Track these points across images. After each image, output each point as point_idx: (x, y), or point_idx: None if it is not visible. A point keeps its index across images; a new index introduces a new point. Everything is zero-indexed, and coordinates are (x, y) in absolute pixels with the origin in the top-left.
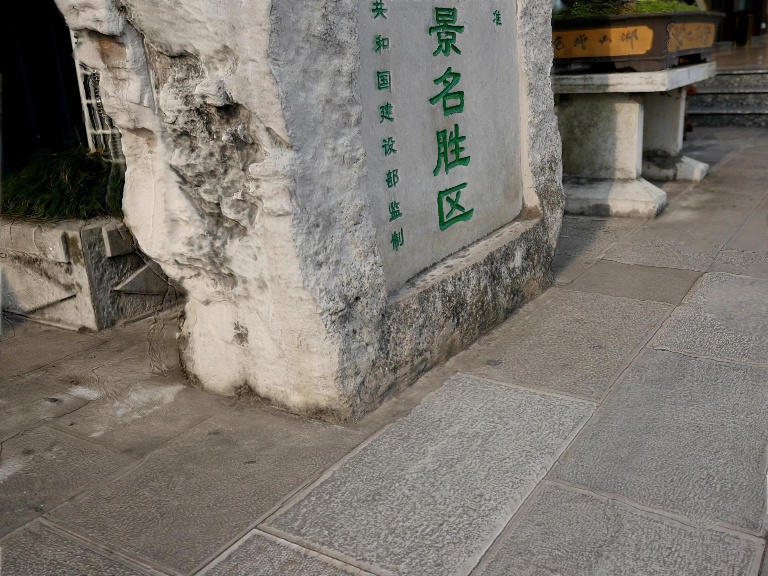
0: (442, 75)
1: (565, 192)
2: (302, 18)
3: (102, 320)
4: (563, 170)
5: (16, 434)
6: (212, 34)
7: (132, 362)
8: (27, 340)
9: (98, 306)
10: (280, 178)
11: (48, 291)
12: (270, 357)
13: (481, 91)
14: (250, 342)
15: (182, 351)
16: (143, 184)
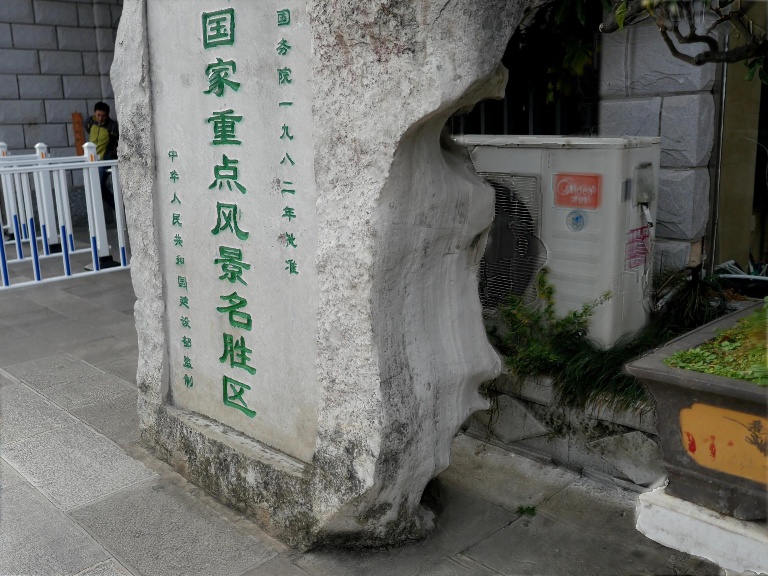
0: (230, 295)
1: None
2: None
3: None
4: None
5: None
6: None
7: None
8: None
9: None
10: None
11: None
12: None
13: (271, 323)
14: None
15: None
16: None
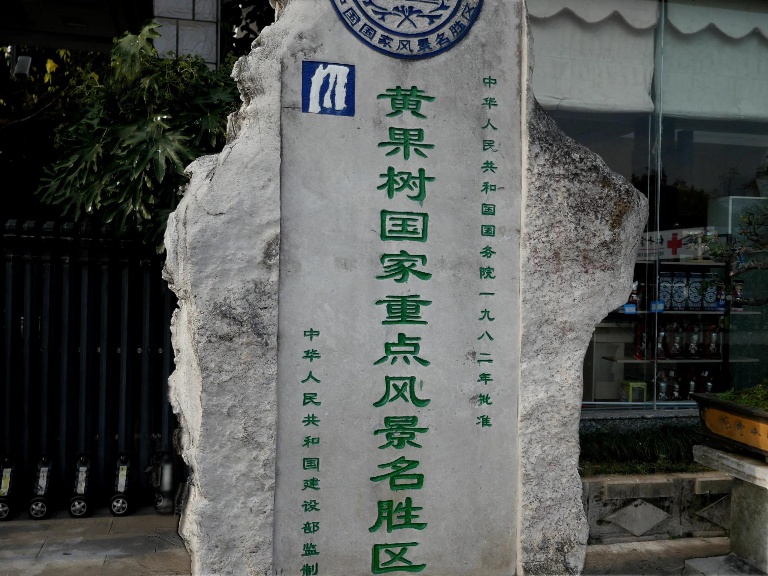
0: (392, 461)
1: (719, 573)
2: (226, 428)
3: None
4: (733, 549)
5: None
6: None
7: None
8: None
9: None
10: (193, 514)
11: None
12: None
13: (452, 475)
14: None
15: None
16: (187, 489)
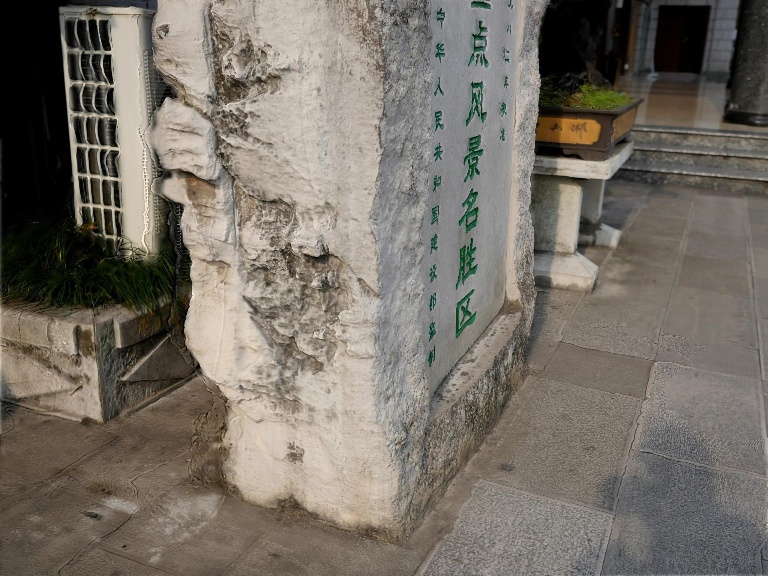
0: (467, 197)
1: None
2: (395, 178)
3: (107, 411)
4: None
5: (71, 560)
6: (315, 191)
7: (166, 470)
8: (30, 433)
9: (104, 397)
10: (368, 326)
11: (56, 384)
12: (326, 477)
13: (488, 203)
14: (305, 462)
15: (223, 462)
16: (211, 311)
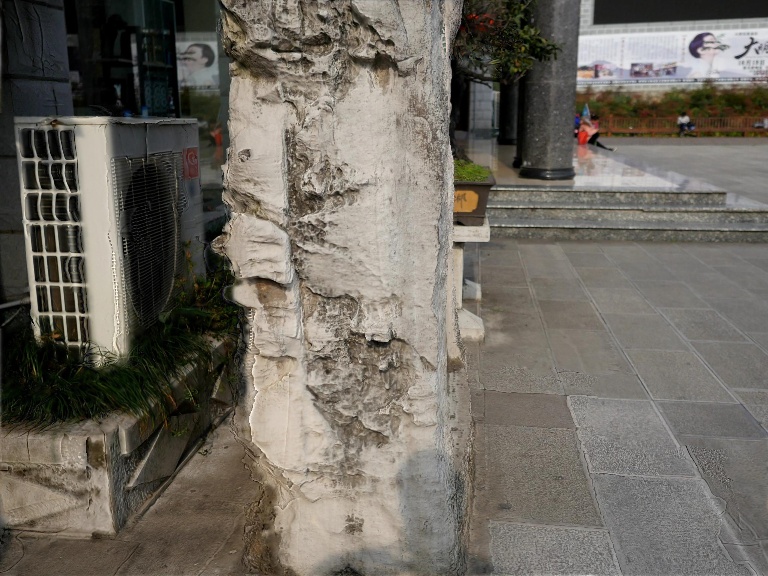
0: None
1: None
2: None
3: (117, 520)
4: None
5: None
6: (384, 285)
7: (218, 565)
8: (44, 557)
9: (114, 506)
10: (433, 397)
11: (70, 501)
12: (386, 541)
13: None
14: (365, 531)
15: None
16: (275, 403)
